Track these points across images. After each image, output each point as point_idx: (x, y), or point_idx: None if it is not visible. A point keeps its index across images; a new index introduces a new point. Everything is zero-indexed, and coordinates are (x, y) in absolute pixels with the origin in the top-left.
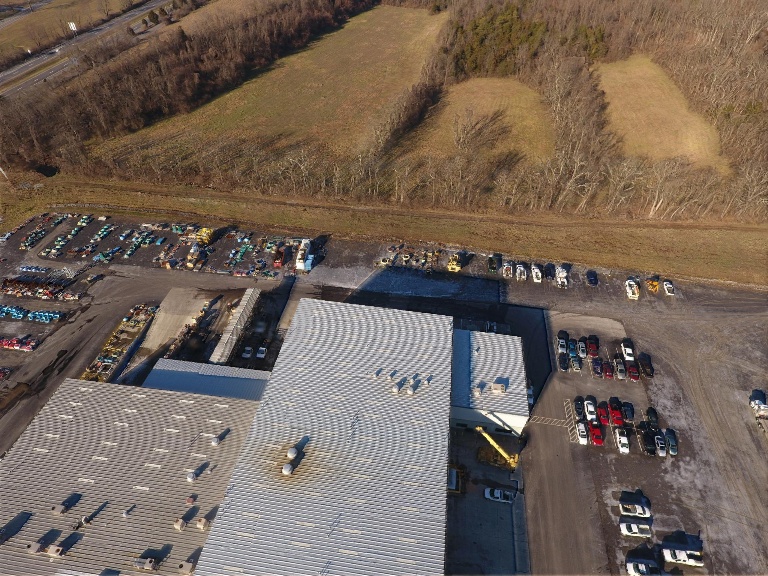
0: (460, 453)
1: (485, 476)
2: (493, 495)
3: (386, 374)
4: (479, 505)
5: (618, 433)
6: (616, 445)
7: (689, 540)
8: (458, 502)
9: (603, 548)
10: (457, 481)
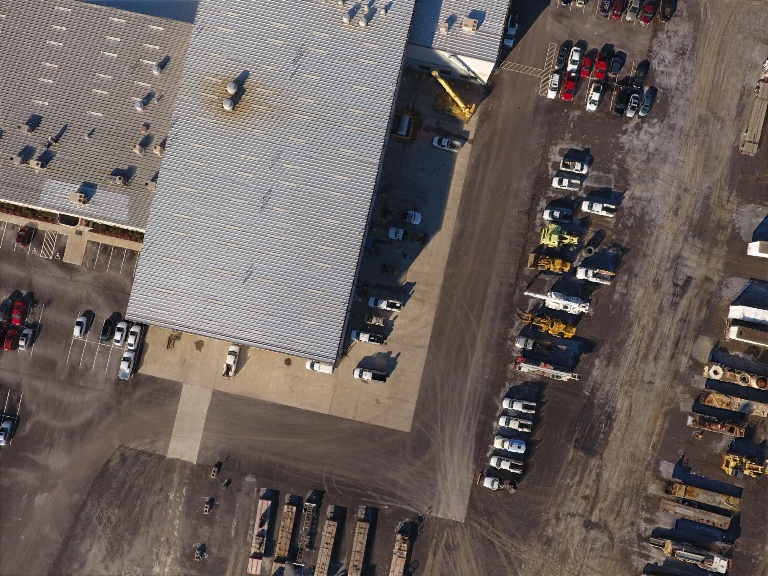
0: (418, 99)
1: (438, 124)
2: (440, 143)
3: None
4: (426, 151)
5: (593, 88)
6: (586, 101)
7: (613, 196)
8: (406, 147)
9: (530, 196)
10: (409, 127)
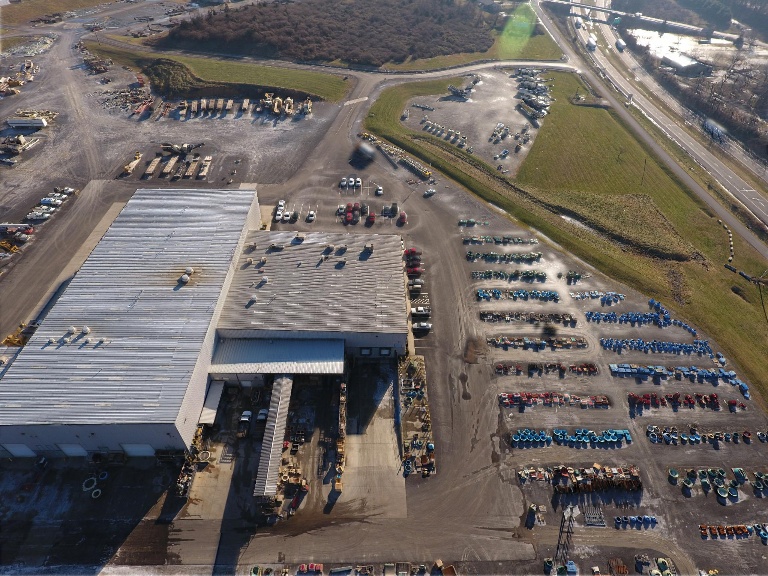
0: None
1: None
2: None
3: (91, 344)
4: None
5: None
6: None
7: None
8: None
9: None
10: None
